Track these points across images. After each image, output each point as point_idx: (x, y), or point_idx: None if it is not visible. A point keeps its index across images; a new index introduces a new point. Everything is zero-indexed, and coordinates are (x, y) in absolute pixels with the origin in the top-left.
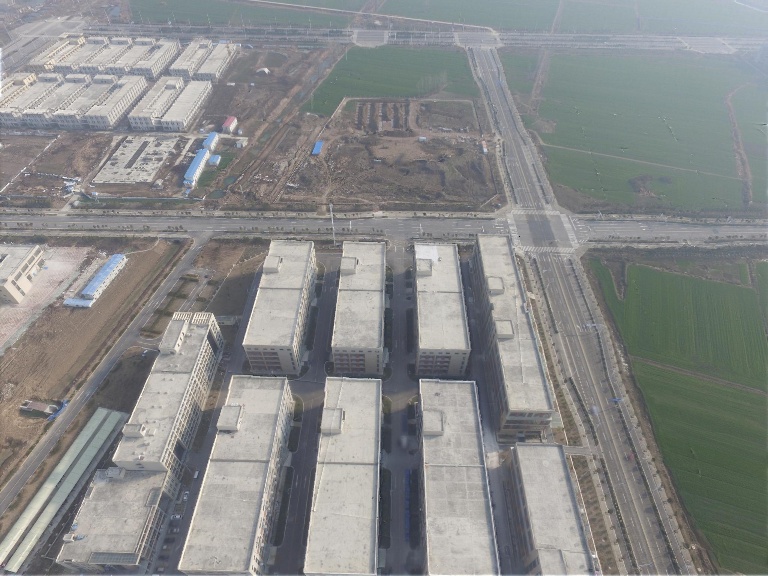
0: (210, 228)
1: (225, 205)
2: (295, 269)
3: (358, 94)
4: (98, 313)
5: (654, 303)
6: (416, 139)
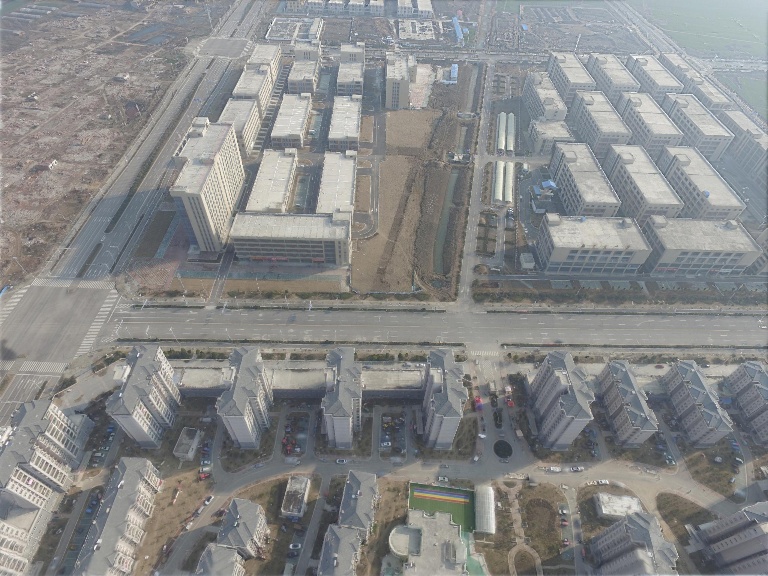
0: (491, 58)
1: (491, 50)
2: (573, 62)
3: (529, 3)
4: (462, 87)
5: (758, 90)
6: (583, 25)
